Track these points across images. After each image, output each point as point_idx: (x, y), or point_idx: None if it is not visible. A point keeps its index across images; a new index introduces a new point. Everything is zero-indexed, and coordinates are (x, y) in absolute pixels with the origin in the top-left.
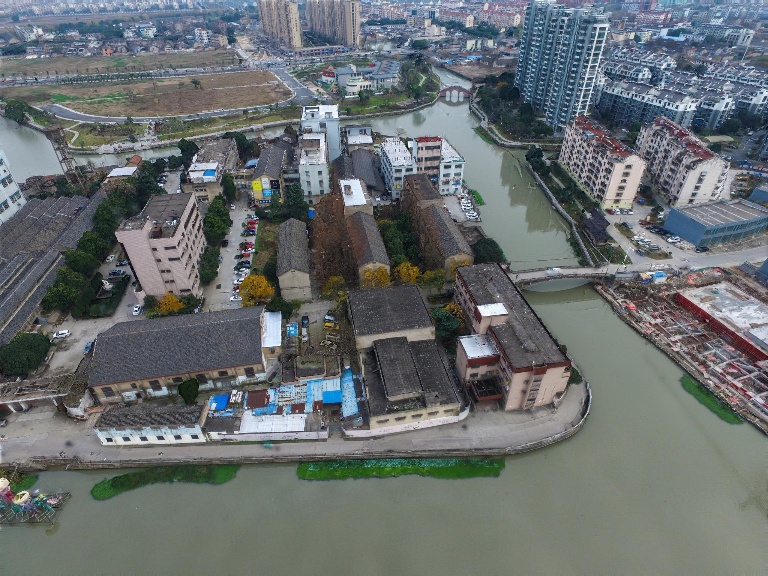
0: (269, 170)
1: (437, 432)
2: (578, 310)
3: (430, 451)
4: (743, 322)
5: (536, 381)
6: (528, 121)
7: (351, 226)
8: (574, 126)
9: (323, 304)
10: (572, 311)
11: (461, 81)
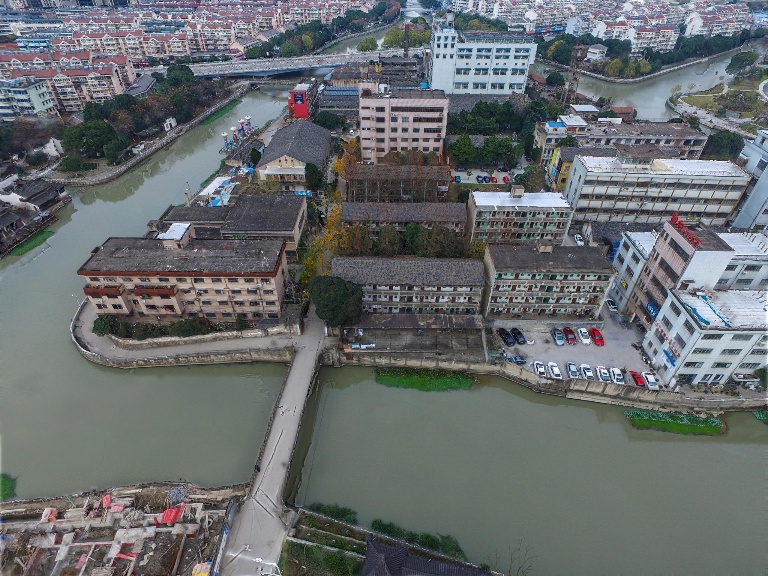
0: (579, 150)
1: None
2: None
3: None
4: None
5: None
6: None
7: None
8: None
9: None
10: None
11: None
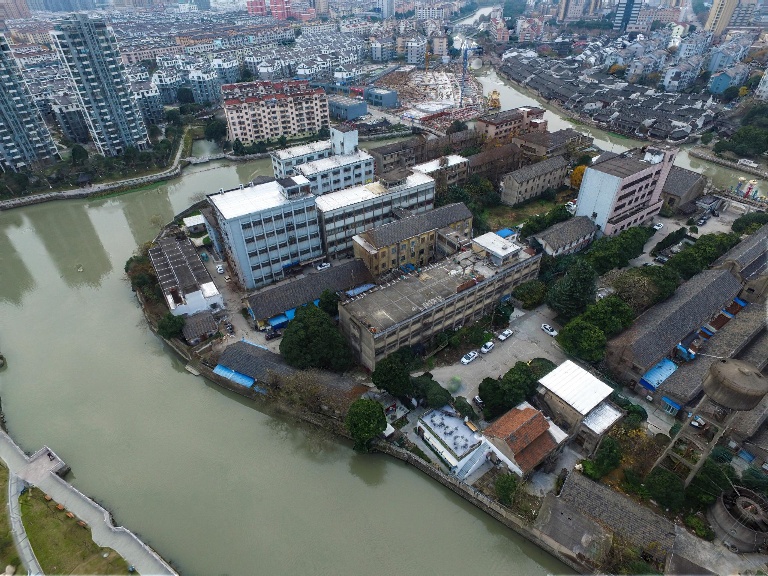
0: (447, 206)
1: None
2: None
3: None
4: None
5: None
6: None
7: (482, 161)
8: (247, 105)
9: None
10: None
11: None
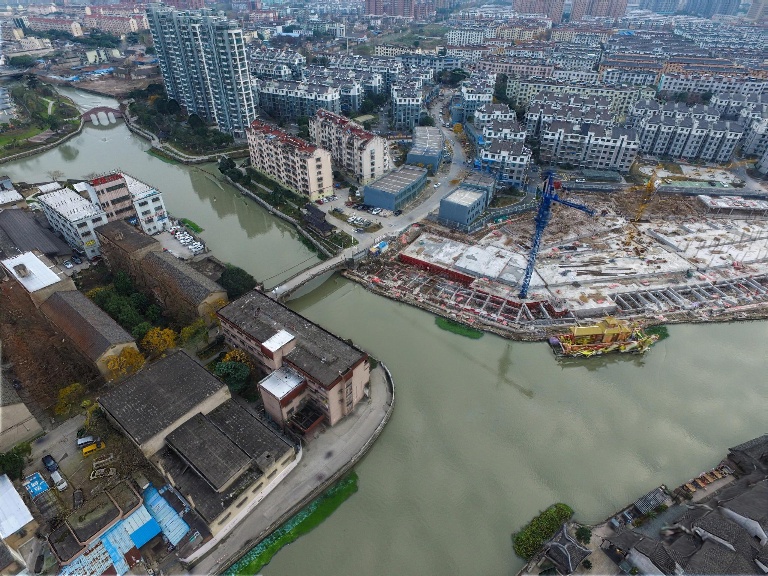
0: None
1: (283, 489)
2: (337, 299)
3: (287, 512)
4: (448, 259)
5: (348, 386)
6: (203, 133)
7: (53, 315)
8: (254, 131)
9: (64, 427)
10: (333, 302)
11: (101, 99)
